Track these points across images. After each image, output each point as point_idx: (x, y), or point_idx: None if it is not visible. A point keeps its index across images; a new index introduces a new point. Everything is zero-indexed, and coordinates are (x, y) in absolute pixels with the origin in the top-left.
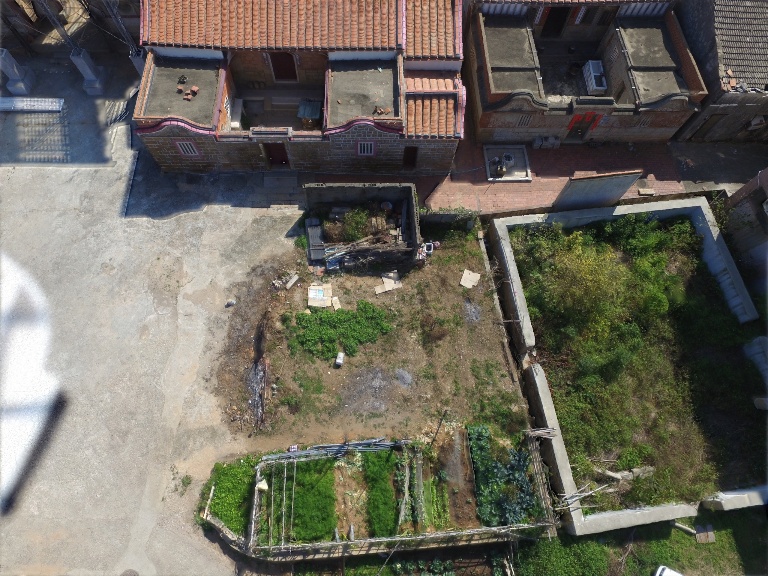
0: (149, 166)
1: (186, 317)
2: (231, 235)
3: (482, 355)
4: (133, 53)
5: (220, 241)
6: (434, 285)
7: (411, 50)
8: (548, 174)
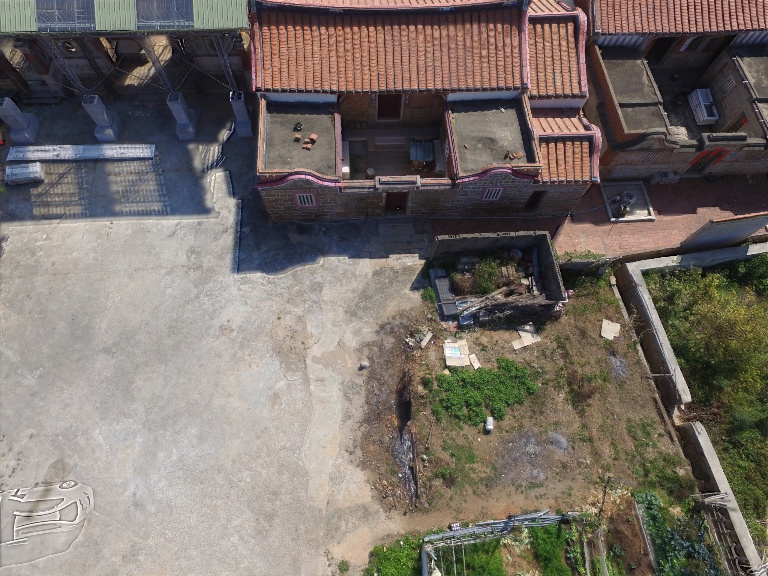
0: (255, 216)
1: (318, 383)
2: (353, 289)
3: (635, 413)
4: (234, 96)
5: (342, 297)
6: (574, 337)
7: (535, 88)
8: (670, 211)
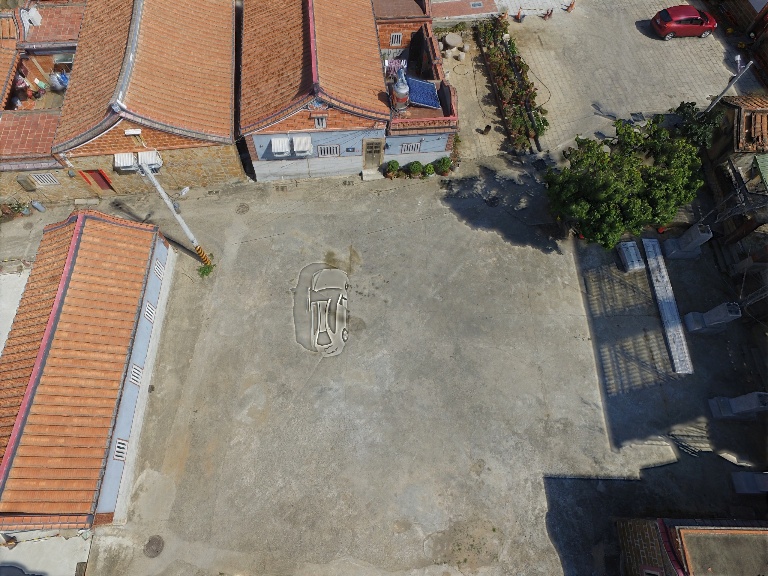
0: (621, 498)
1: None
2: None
3: None
4: None
5: None
6: None
7: None
8: None
